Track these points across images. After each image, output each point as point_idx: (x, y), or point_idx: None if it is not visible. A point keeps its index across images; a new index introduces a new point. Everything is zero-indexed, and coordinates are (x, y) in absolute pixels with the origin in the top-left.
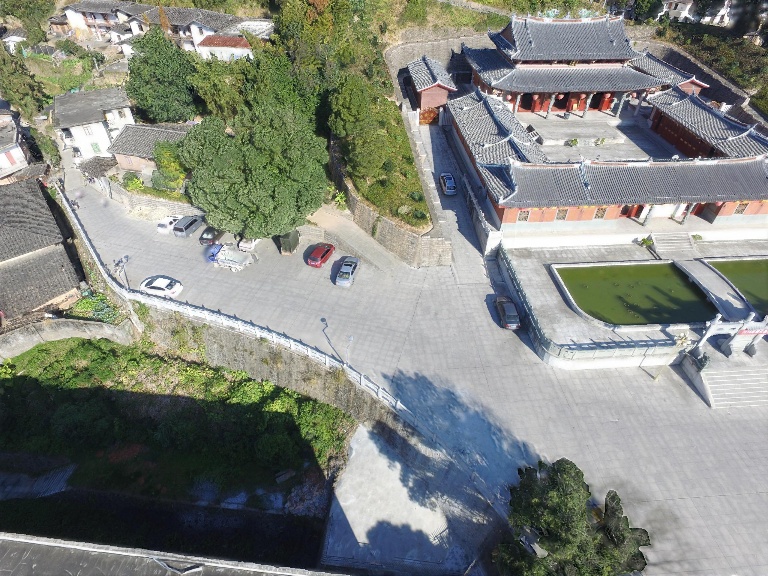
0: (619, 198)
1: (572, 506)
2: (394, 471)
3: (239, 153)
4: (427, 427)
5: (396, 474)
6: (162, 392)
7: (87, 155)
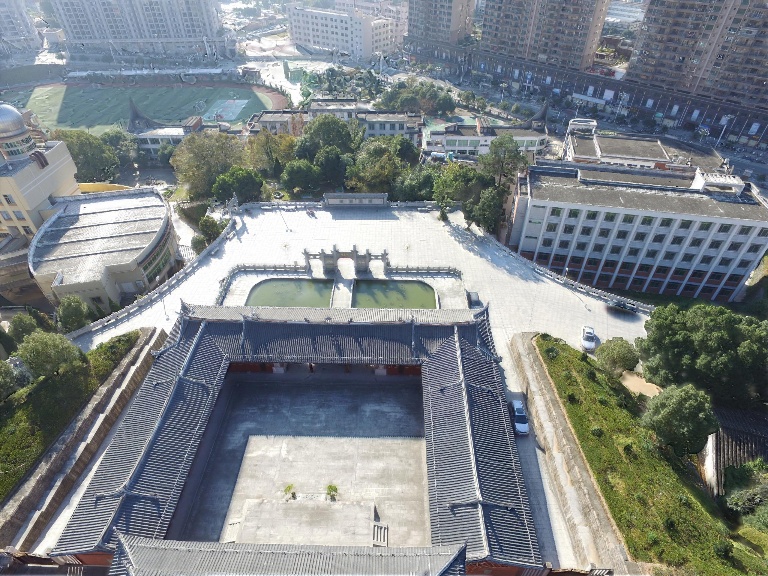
0: (390, 310)
1: None
2: None
3: None
4: None
5: None
6: None
7: None
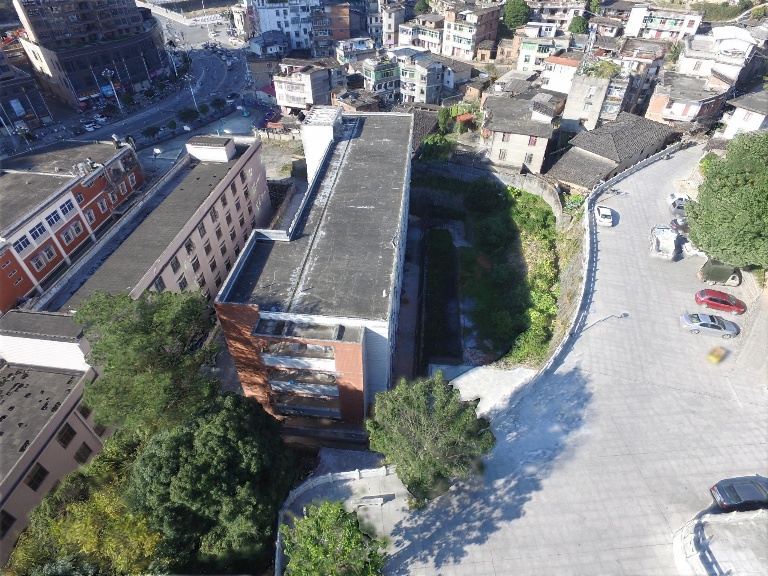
0: None
1: (434, 390)
2: (501, 399)
3: (763, 169)
4: (528, 385)
5: (499, 401)
6: (526, 257)
7: (727, 135)
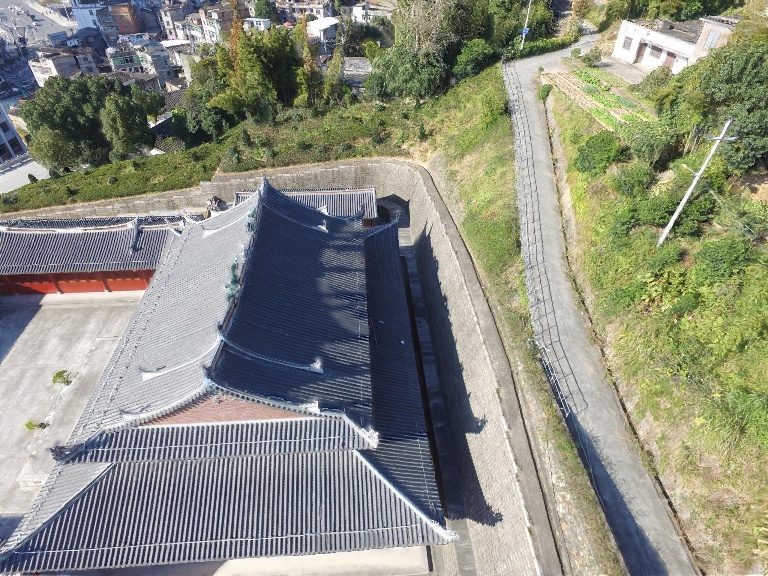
0: None
1: None
2: None
3: None
4: None
5: None
6: None
7: None
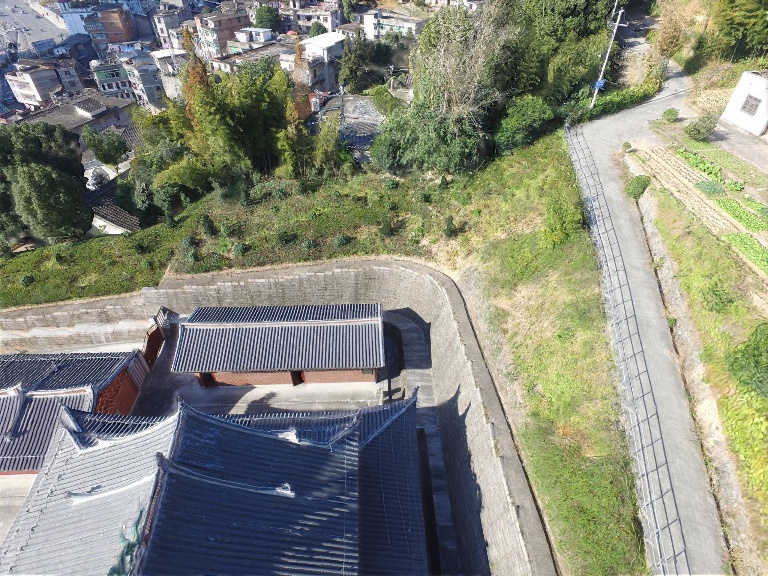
0: None
1: None
2: None
3: None
4: None
5: None
6: None
7: None
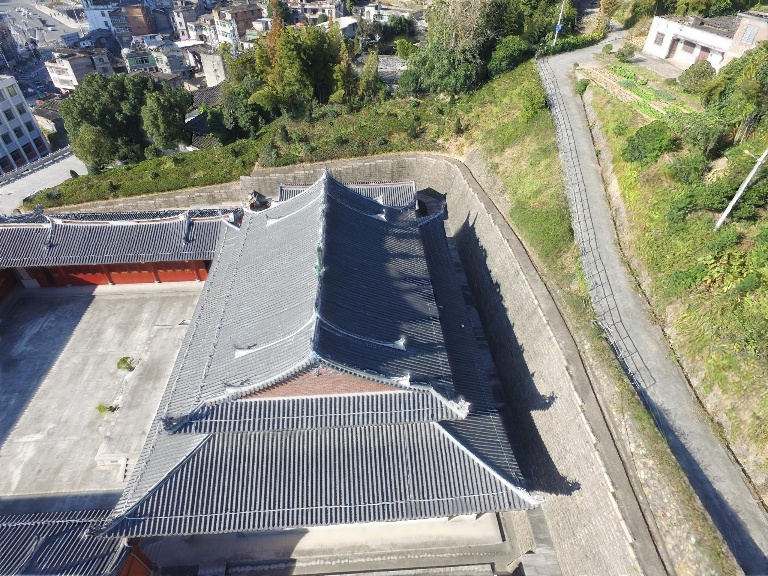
0: None
1: None
2: None
3: None
4: None
5: None
6: None
7: None
